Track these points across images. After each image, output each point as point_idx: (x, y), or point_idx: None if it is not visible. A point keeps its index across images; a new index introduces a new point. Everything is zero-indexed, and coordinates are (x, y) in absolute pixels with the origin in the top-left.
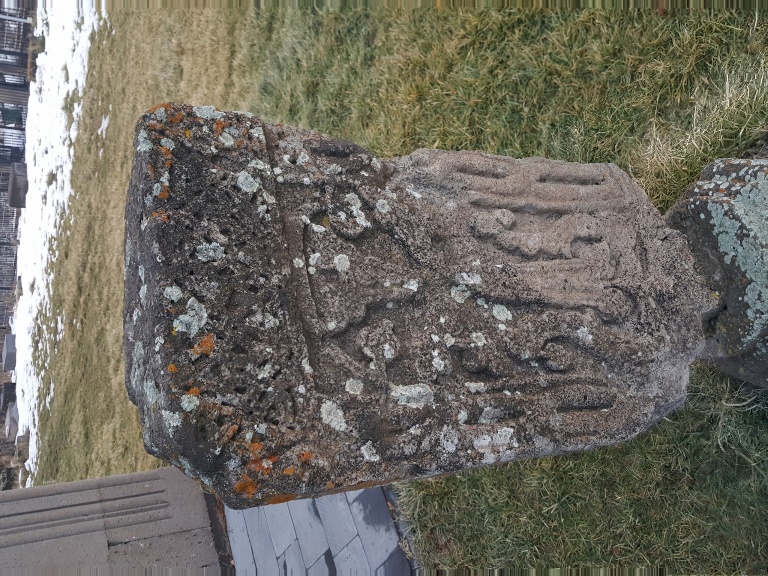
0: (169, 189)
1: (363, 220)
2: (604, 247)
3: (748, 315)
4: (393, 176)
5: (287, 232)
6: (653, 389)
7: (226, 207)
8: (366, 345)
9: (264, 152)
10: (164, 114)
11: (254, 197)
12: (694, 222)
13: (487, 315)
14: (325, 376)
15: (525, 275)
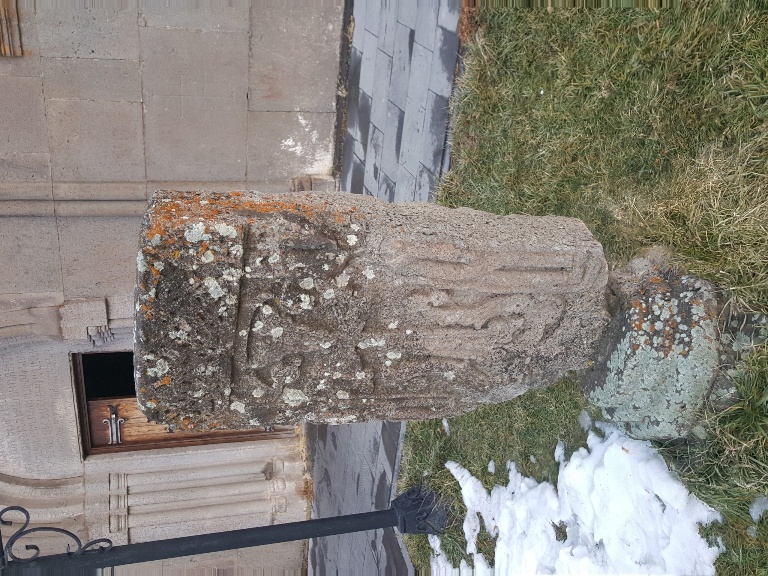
0: (155, 298)
1: (306, 306)
2: (518, 324)
3: (591, 393)
4: (359, 256)
5: (241, 315)
6: (484, 400)
7: (195, 309)
8: (274, 377)
9: (238, 263)
10: (159, 242)
11: (220, 299)
12: (620, 322)
13: (381, 356)
14: (241, 388)
15: (427, 340)
